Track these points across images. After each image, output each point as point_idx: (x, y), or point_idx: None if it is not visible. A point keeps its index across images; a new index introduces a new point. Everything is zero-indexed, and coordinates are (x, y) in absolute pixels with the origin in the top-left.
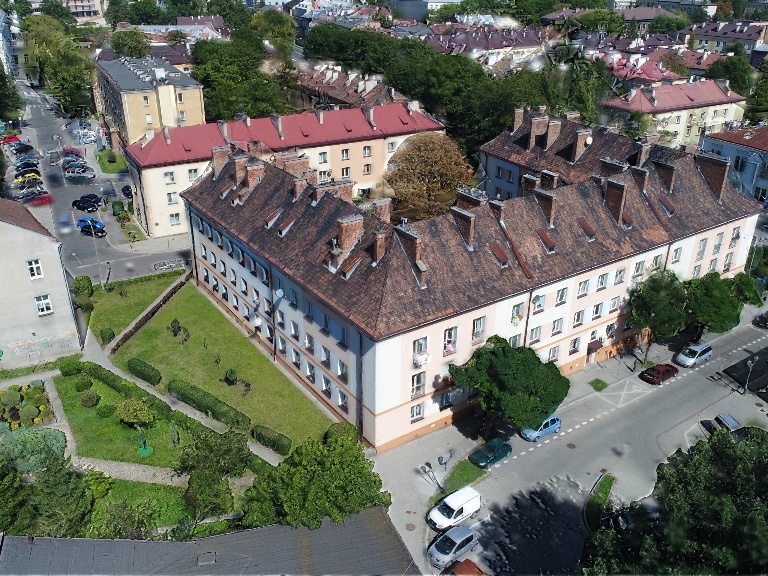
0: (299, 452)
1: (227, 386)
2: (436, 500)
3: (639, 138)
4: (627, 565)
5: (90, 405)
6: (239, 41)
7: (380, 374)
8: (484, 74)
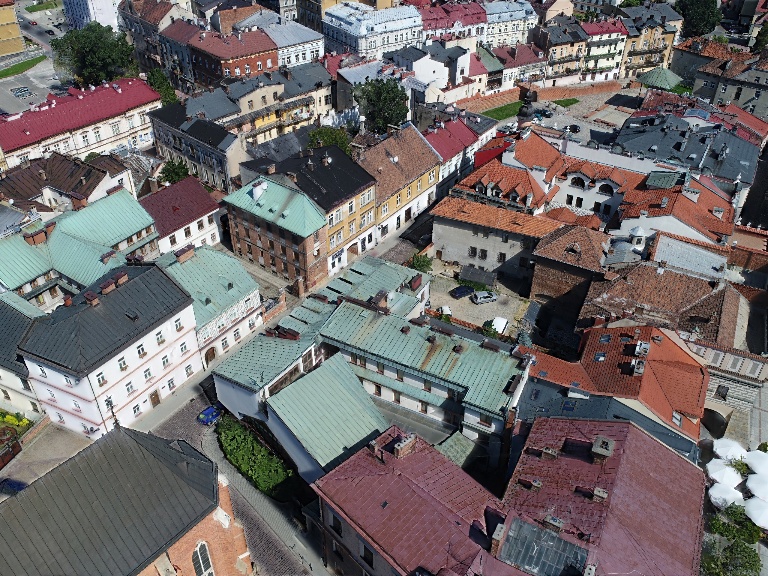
0: None
1: None
2: None
3: None
4: (680, 4)
5: None
6: None
7: None
8: None
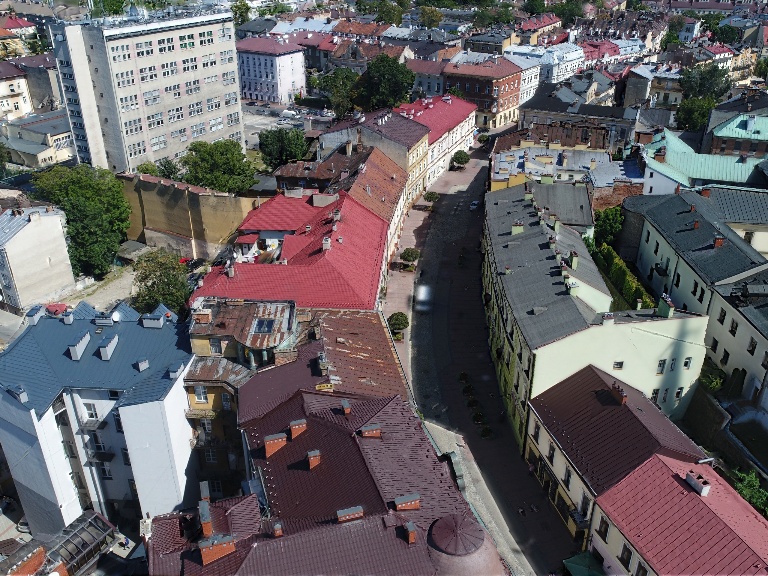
0: None
1: None
2: None
3: (640, 11)
4: (713, 42)
5: None
6: (427, 0)
7: None
8: (549, 4)
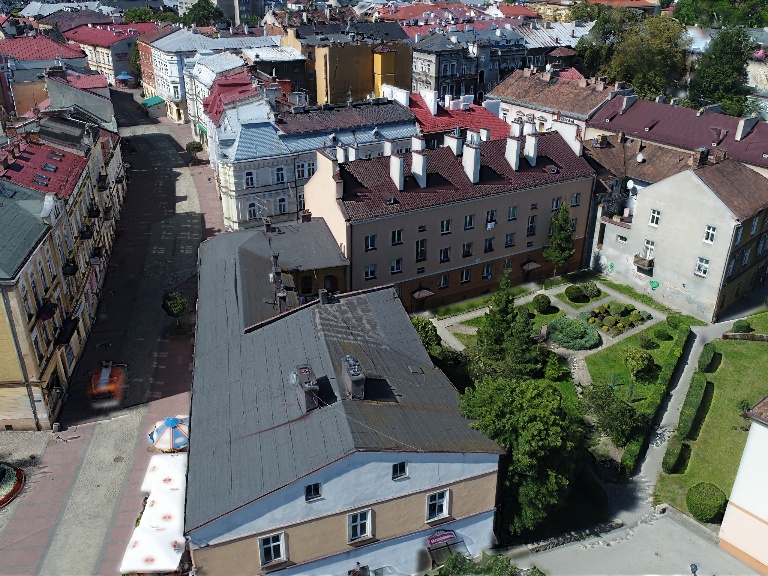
0: None
1: (738, 414)
2: None
3: None
4: None
5: (640, 344)
6: None
7: (749, 461)
8: None
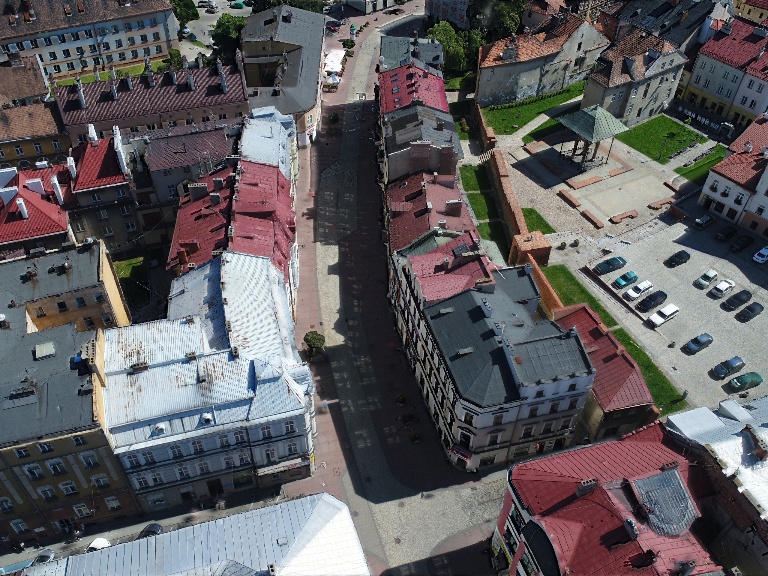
0: (224, 21)
1: None
2: (208, 48)
3: None
4: None
5: None
6: None
7: None
8: None
